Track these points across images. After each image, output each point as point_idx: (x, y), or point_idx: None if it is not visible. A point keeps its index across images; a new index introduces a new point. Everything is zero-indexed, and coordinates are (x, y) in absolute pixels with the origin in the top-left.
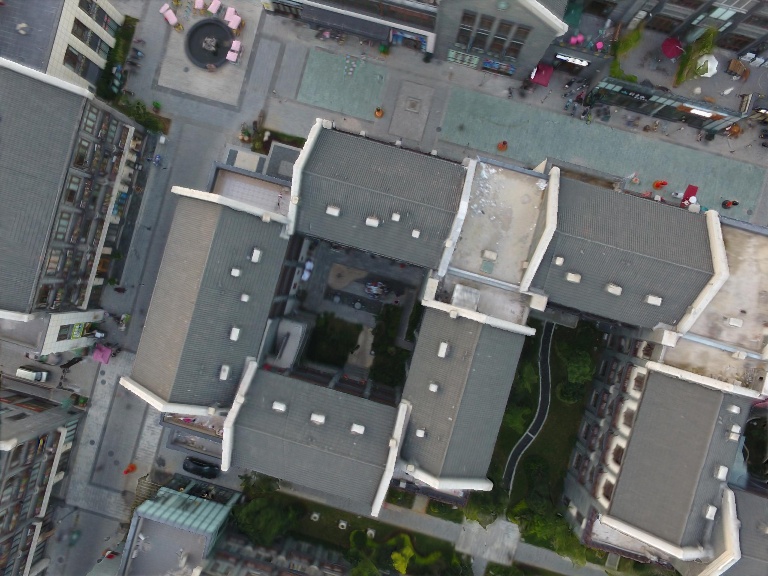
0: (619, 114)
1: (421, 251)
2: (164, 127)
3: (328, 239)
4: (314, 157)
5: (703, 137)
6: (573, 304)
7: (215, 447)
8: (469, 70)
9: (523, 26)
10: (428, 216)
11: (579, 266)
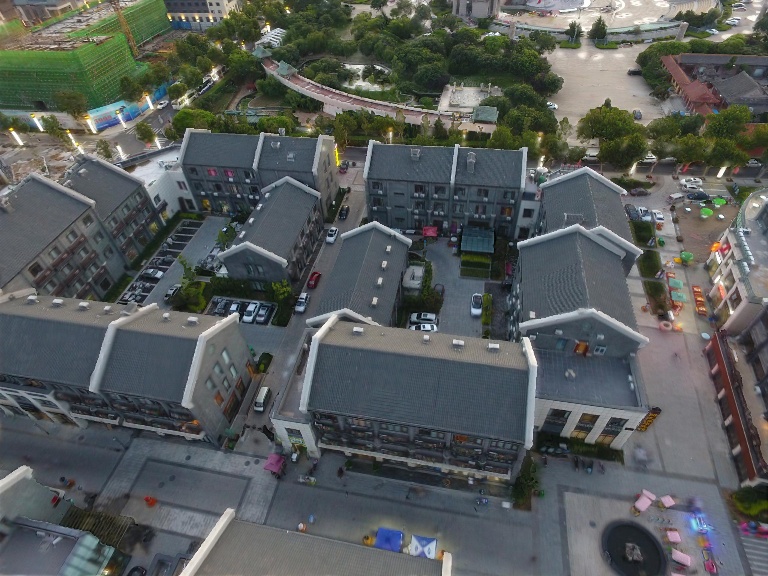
0: None
1: None
2: (521, 504)
3: None
4: None
5: None
6: None
7: None
8: None
9: None
10: None
11: None
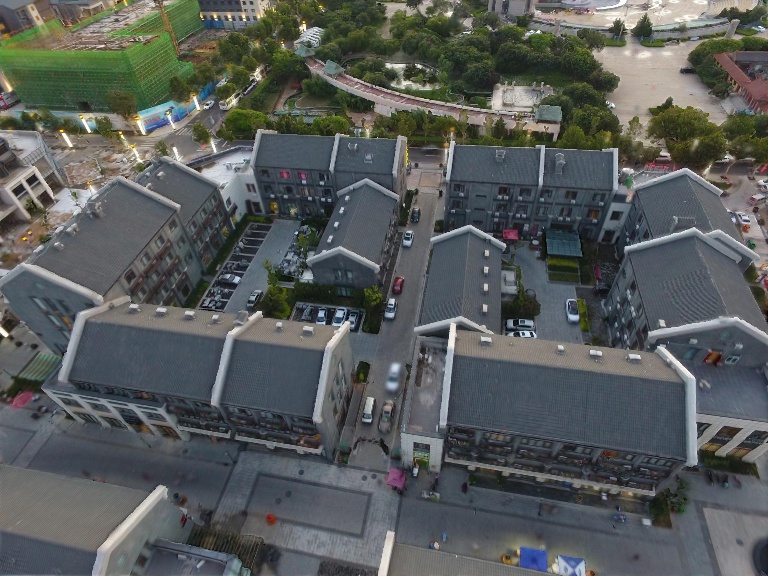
0: None
1: None
2: (661, 521)
3: None
4: None
5: None
6: None
7: None
8: None
9: None
10: None
11: None
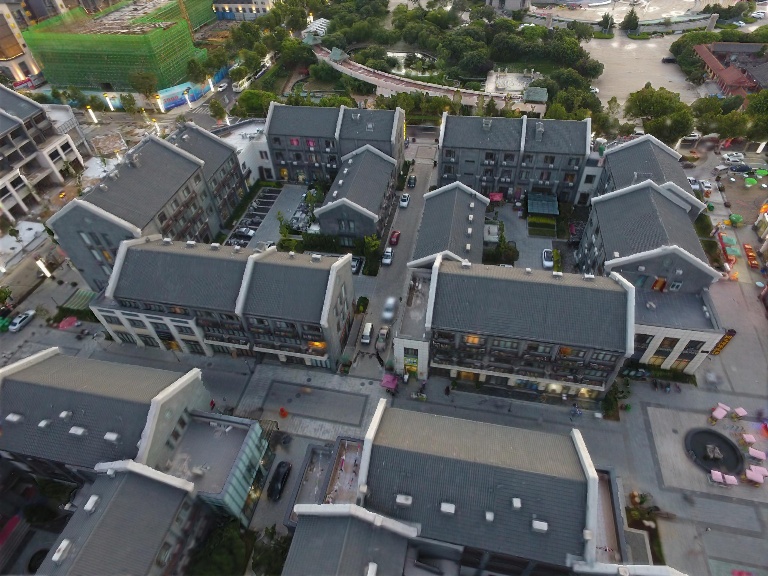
0: None
1: None
2: (610, 416)
3: None
4: None
5: None
6: None
7: (306, 494)
8: None
9: None
10: None
11: None
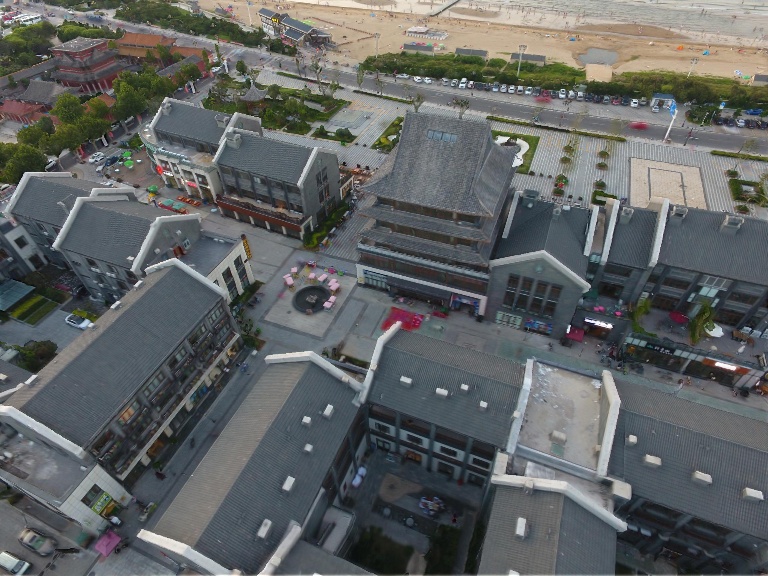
0: (651, 370)
1: (488, 427)
2: (259, 345)
3: (397, 410)
4: (394, 340)
5: (738, 393)
6: (662, 499)
7: None
8: (514, 330)
9: (556, 285)
10: (494, 390)
11: (655, 449)
